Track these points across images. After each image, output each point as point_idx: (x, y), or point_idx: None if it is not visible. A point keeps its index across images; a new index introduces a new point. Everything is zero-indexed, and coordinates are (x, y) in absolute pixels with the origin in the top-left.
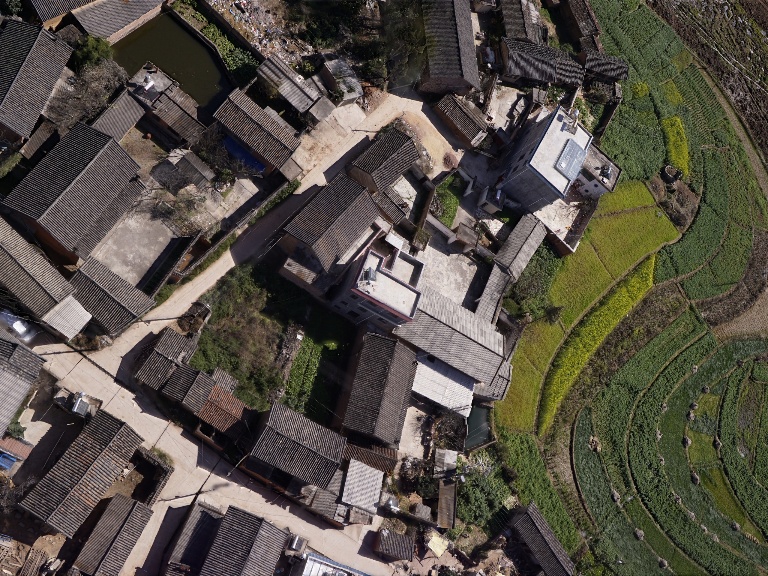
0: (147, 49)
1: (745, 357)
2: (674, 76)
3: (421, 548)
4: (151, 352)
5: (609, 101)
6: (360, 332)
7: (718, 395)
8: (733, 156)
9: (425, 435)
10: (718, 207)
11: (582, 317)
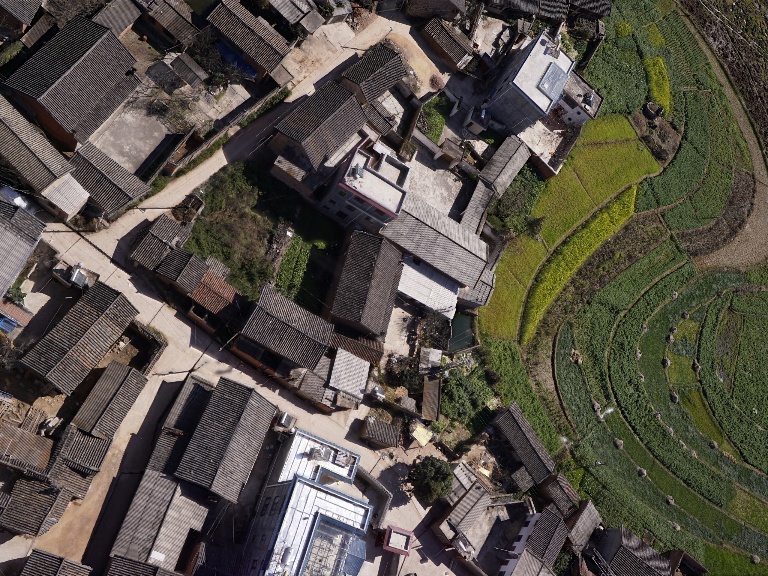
0: None
1: (724, 288)
2: (657, 20)
3: (406, 439)
4: (146, 234)
5: (592, 38)
6: (348, 233)
7: (698, 322)
8: (714, 99)
9: (411, 335)
10: (699, 145)
11: (565, 238)
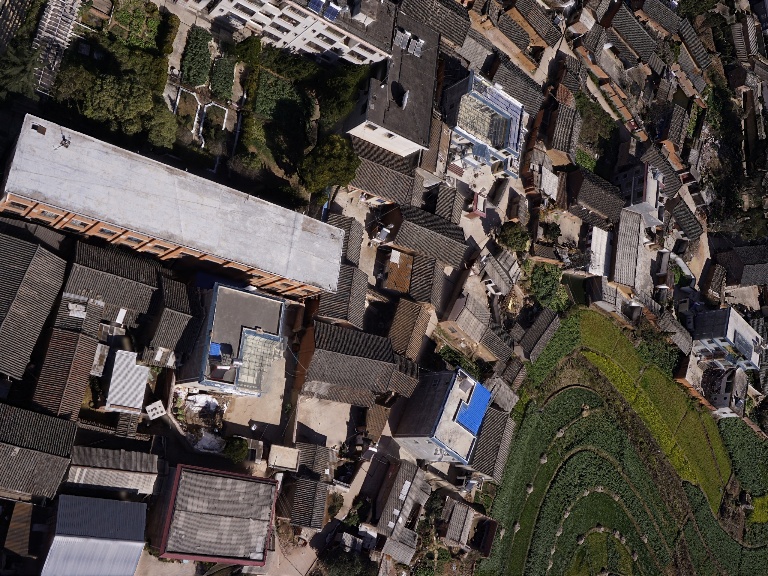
0: None
1: None
2: None
3: None
4: None
5: (763, 429)
6: None
7: (633, 575)
8: None
9: None
10: (744, 567)
11: None
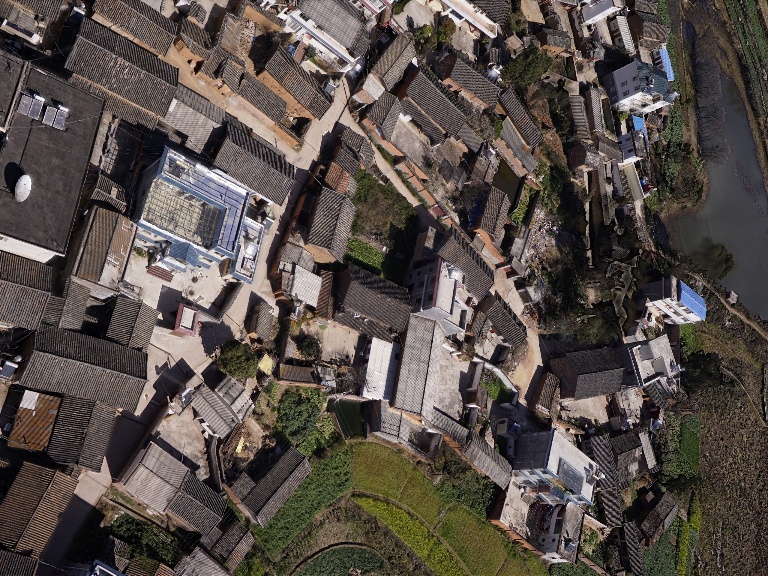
0: None
1: None
2: None
3: (257, 356)
4: None
5: (610, 569)
6: None
7: None
8: None
9: None
10: None
11: (450, 552)
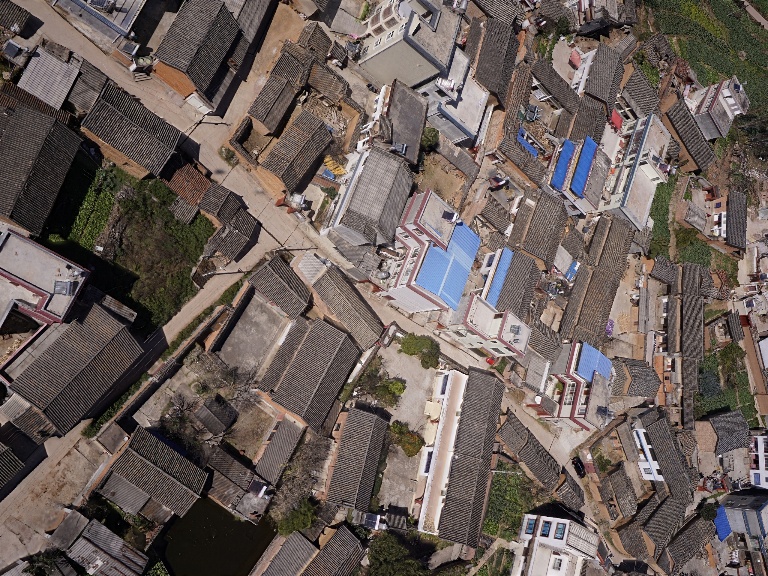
0: (226, 567)
1: None
2: None
3: None
4: None
5: None
6: None
7: None
8: None
9: None
10: None
11: None
